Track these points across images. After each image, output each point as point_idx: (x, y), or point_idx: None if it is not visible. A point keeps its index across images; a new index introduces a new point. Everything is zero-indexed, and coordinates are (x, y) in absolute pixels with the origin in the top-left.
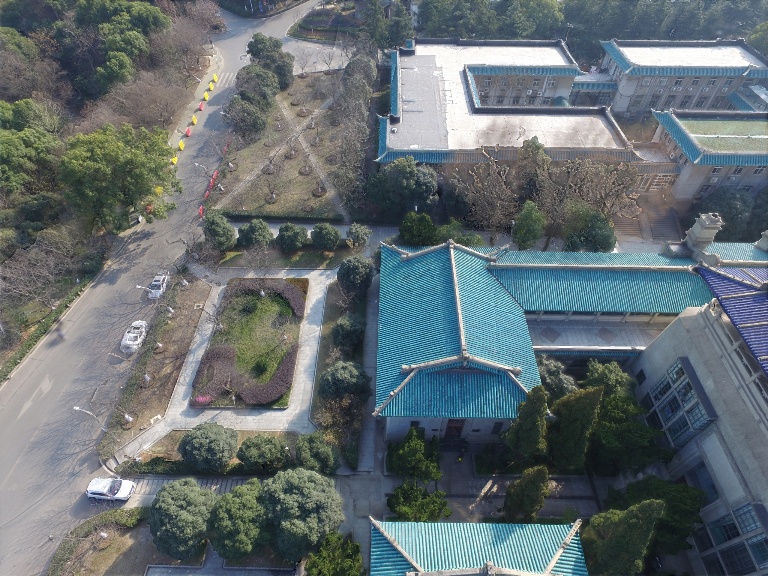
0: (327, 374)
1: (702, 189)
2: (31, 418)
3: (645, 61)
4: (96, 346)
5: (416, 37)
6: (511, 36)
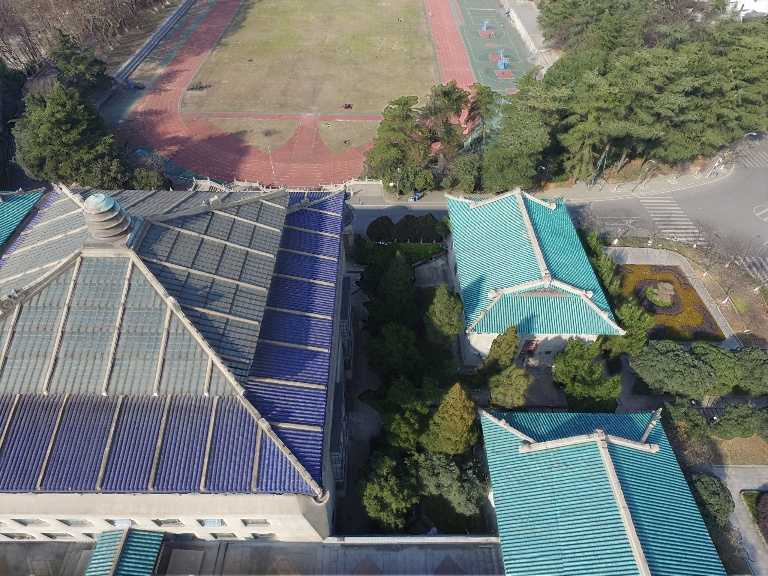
0: None
1: None
2: None
3: None
4: None
5: None
6: None
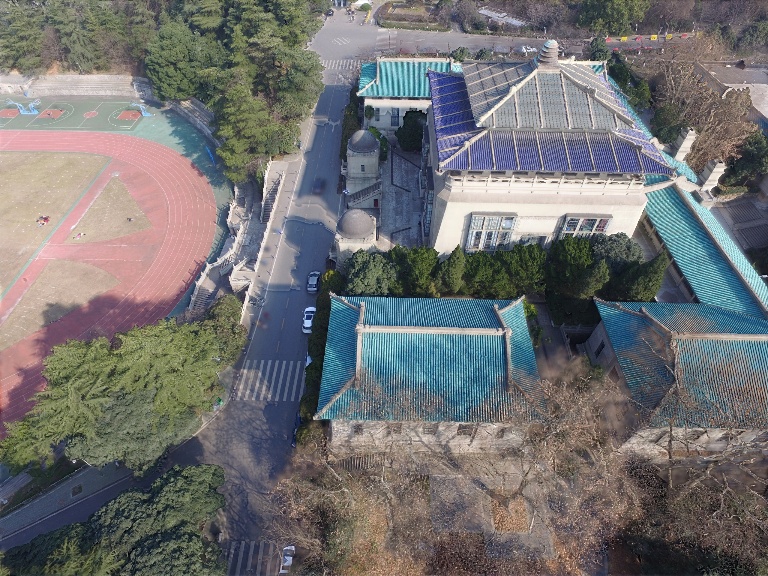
0: None
1: None
2: (486, 43)
3: None
4: None
5: None
6: None
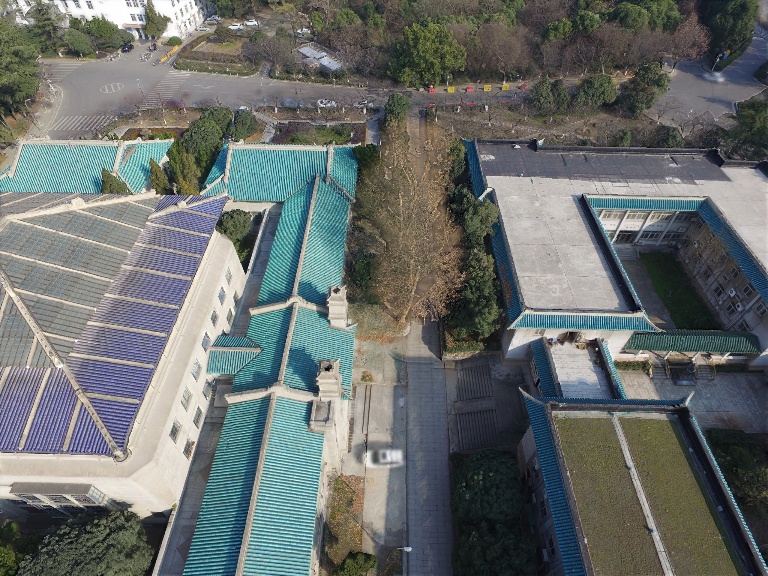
0: None
1: None
2: None
3: None
4: None
5: None
6: None
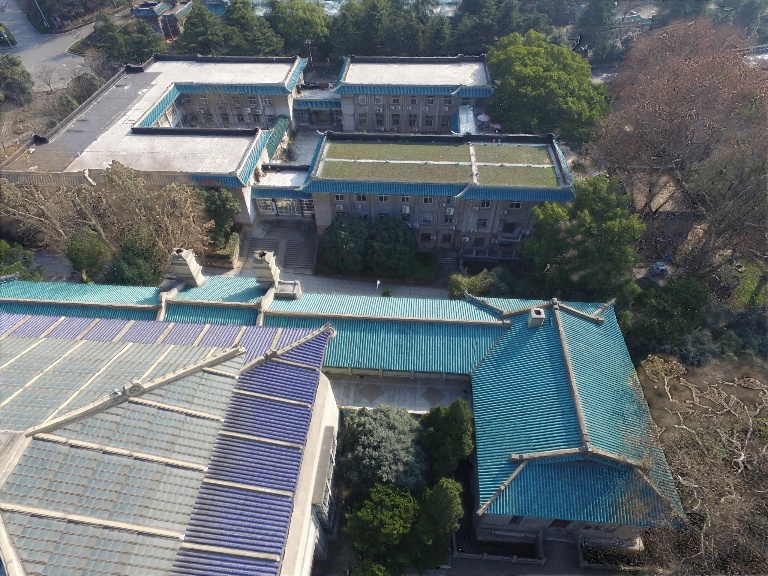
0: None
1: None
2: None
3: (365, 79)
4: None
5: (157, 54)
6: (256, 52)
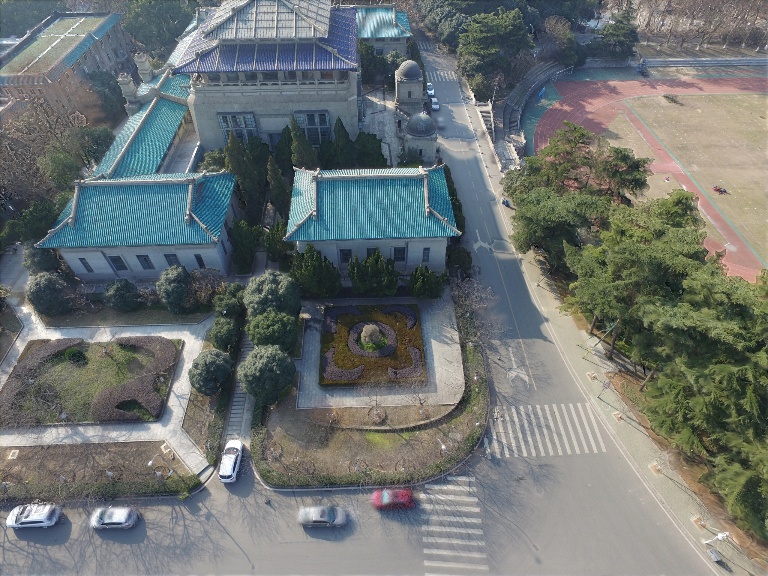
0: (168, 288)
1: (68, 100)
2: None
3: None
4: (26, 573)
5: None
6: None
